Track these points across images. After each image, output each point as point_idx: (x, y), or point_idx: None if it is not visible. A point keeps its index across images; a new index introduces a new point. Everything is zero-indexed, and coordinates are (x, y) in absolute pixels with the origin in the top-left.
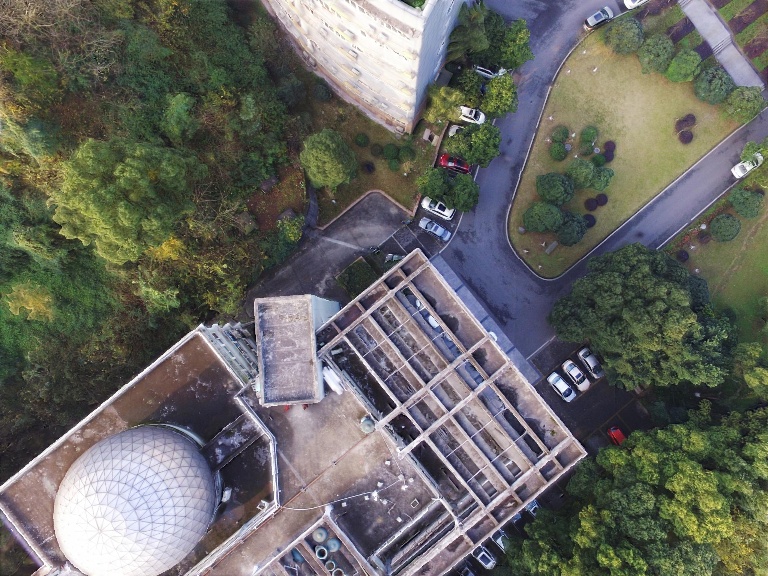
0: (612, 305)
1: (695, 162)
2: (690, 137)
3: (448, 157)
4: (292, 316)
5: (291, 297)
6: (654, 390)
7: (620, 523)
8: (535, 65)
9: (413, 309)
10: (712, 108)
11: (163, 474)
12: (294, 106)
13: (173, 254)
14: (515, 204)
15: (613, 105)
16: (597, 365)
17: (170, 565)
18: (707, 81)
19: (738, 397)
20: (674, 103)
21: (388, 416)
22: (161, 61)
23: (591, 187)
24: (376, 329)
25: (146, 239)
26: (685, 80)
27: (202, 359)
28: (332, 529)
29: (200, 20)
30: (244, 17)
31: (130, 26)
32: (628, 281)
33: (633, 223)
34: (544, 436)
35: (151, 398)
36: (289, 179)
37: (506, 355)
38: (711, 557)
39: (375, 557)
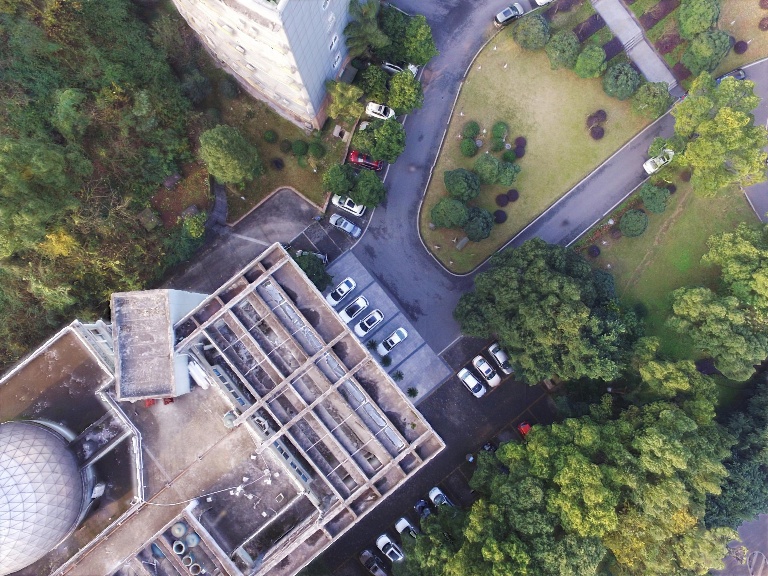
0: (511, 300)
1: (607, 158)
2: (601, 133)
3: (358, 153)
4: (150, 310)
5: (148, 291)
6: (566, 385)
7: (509, 517)
8: (446, 61)
9: (274, 303)
10: (624, 104)
11: (13, 470)
12: (200, 102)
13: (64, 250)
14: (426, 200)
15: (524, 101)
16: (507, 360)
17: (24, 561)
18: (613, 77)
19: (641, 391)
20: (585, 99)
21: (247, 410)
22: (50, 57)
23: (498, 183)
24: (236, 323)
25: (20, 235)
26: (593, 76)
27: (76, 355)
28: (190, 524)
29: (98, 16)
30: (152, 14)
31: (11, 21)
32: (525, 276)
33: (545, 219)
34: (405, 429)
35: (24, 394)
36: (194, 175)
37: (365, 348)
38: (597, 550)
39: (243, 552)
